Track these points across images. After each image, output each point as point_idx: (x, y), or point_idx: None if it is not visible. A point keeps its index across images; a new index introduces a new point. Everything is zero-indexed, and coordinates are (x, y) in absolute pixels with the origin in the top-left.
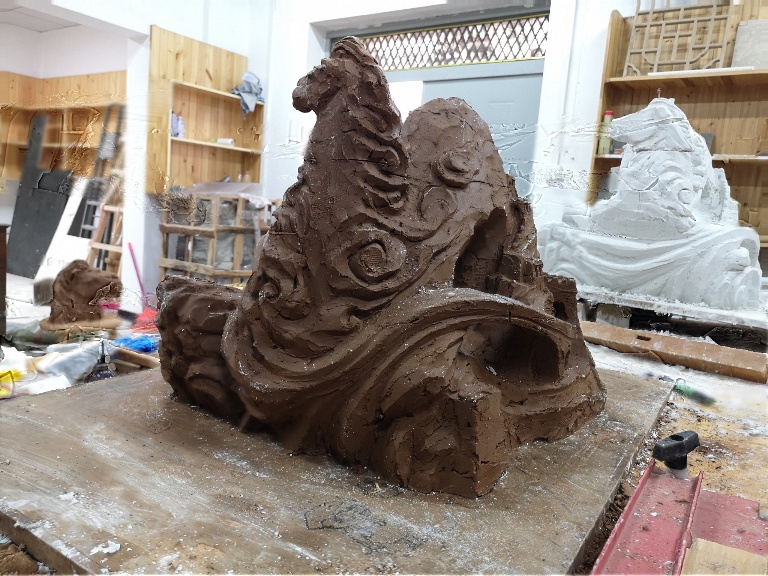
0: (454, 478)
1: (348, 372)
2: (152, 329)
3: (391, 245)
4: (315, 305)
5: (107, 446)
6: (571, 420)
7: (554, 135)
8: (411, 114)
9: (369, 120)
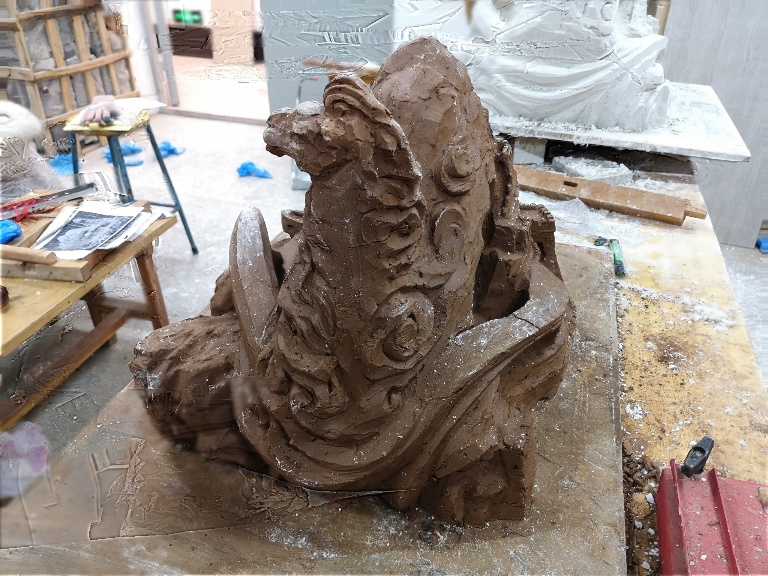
0: (504, 508)
1: (400, 455)
2: (3, 191)
3: (419, 309)
4: (353, 398)
5: (156, 563)
6: (563, 371)
7: (502, 2)
8: (398, 106)
9: (389, 192)
